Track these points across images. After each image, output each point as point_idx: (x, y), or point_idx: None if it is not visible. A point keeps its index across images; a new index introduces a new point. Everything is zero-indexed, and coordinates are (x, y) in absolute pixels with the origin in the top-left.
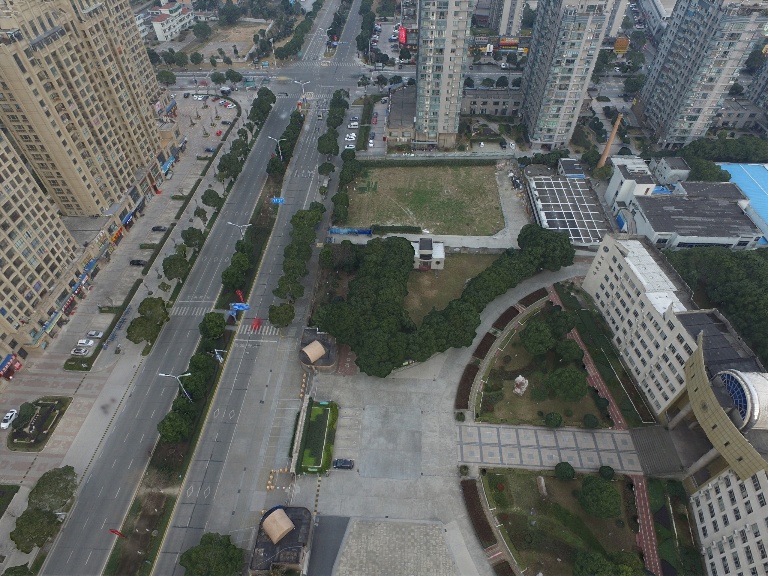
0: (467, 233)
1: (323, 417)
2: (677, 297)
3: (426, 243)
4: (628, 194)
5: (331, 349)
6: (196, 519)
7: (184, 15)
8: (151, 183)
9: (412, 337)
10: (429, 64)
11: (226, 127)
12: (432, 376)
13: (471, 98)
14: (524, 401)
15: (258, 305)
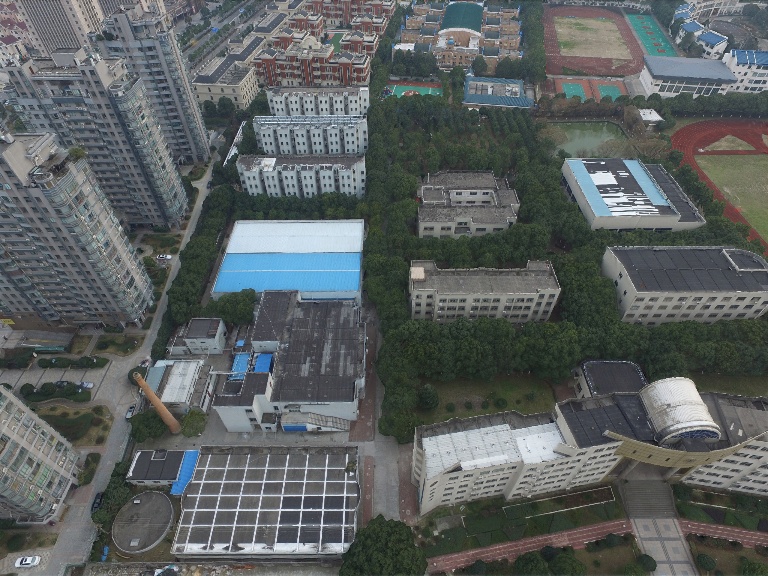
0: None
1: None
2: (518, 428)
3: None
4: (262, 407)
5: None
6: None
7: None
8: None
9: None
10: None
11: None
12: None
13: None
14: None
15: None
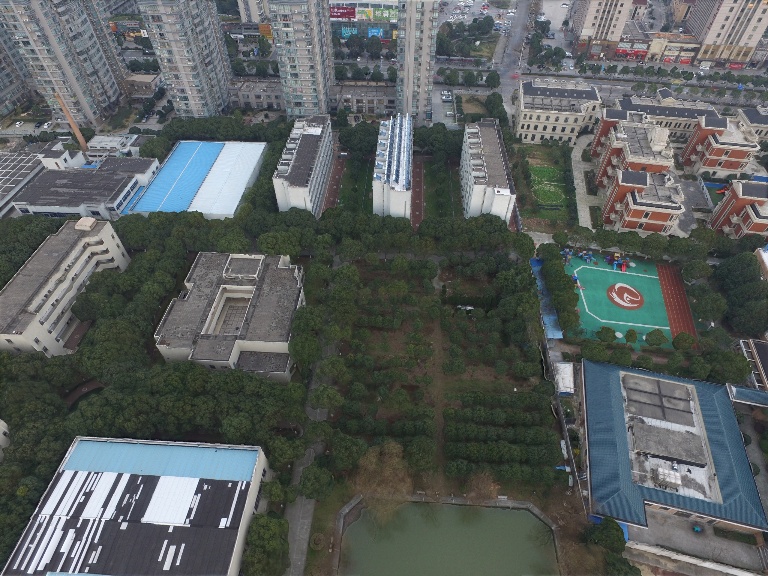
0: None
1: None
2: None
3: None
4: None
5: None
6: None
7: None
8: None
9: None
10: None
11: None
12: None
13: None
14: None
15: None
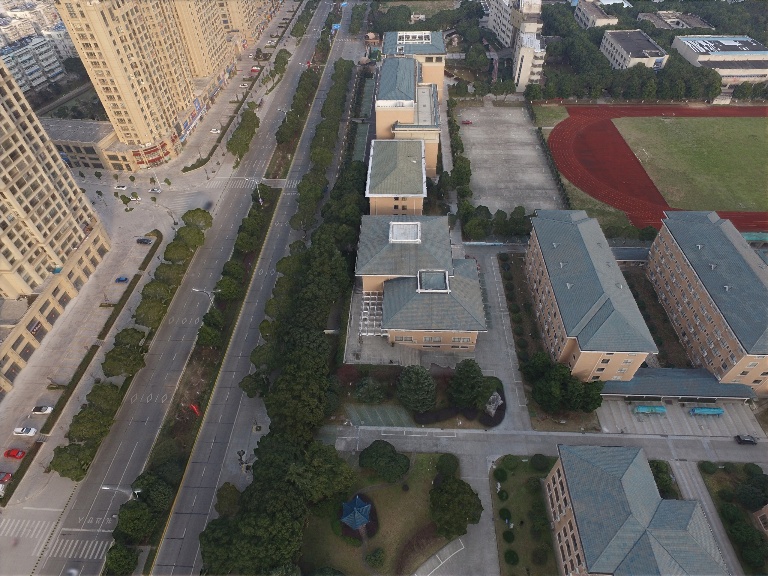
0: None
1: (376, 52)
2: None
3: None
4: None
5: (377, 37)
6: (333, 69)
7: None
8: (277, 4)
9: None
10: None
11: None
12: None
13: None
14: (456, 48)
15: (341, 35)
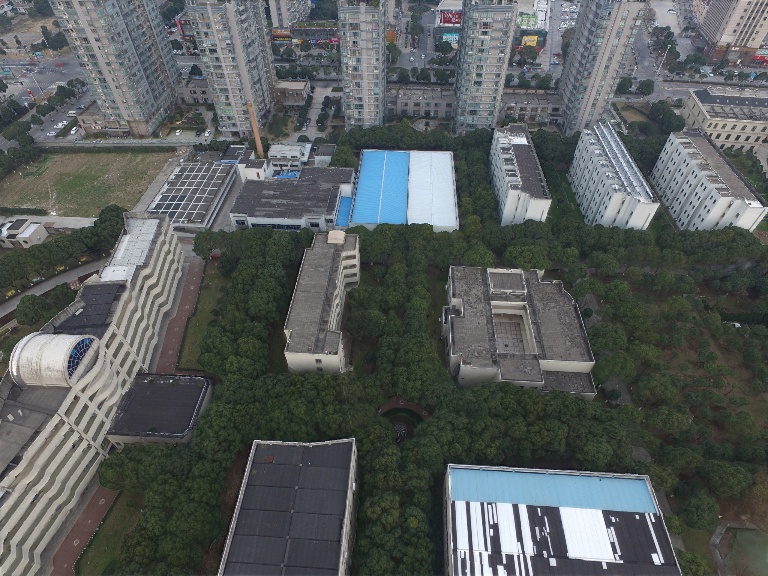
0: (90, 215)
1: None
2: (136, 271)
3: (20, 223)
4: None
5: None
6: None
7: None
8: None
9: None
10: (81, 53)
11: None
12: None
13: (189, 87)
14: None
15: None
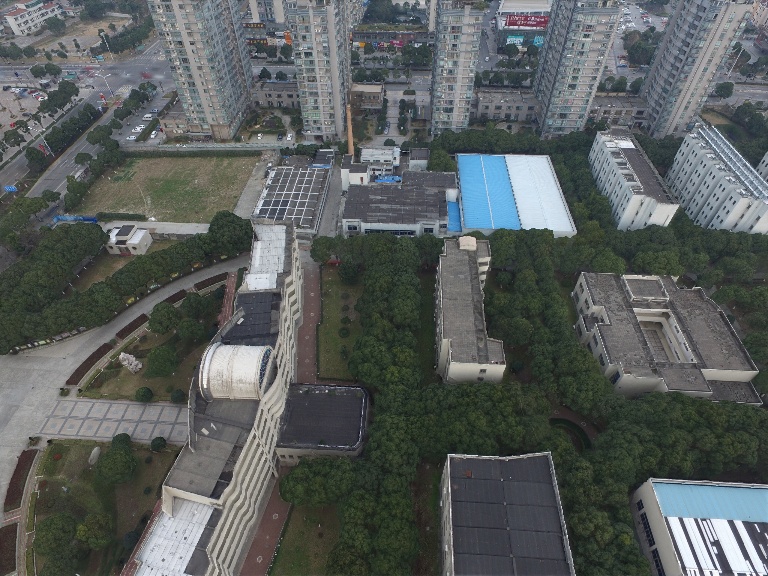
0: (190, 221)
1: None
2: (278, 278)
3: (127, 229)
4: None
5: None
6: None
7: (46, 10)
8: None
9: (29, 316)
10: (174, 56)
11: (25, 119)
12: (65, 354)
13: (265, 91)
14: (135, 378)
15: None
